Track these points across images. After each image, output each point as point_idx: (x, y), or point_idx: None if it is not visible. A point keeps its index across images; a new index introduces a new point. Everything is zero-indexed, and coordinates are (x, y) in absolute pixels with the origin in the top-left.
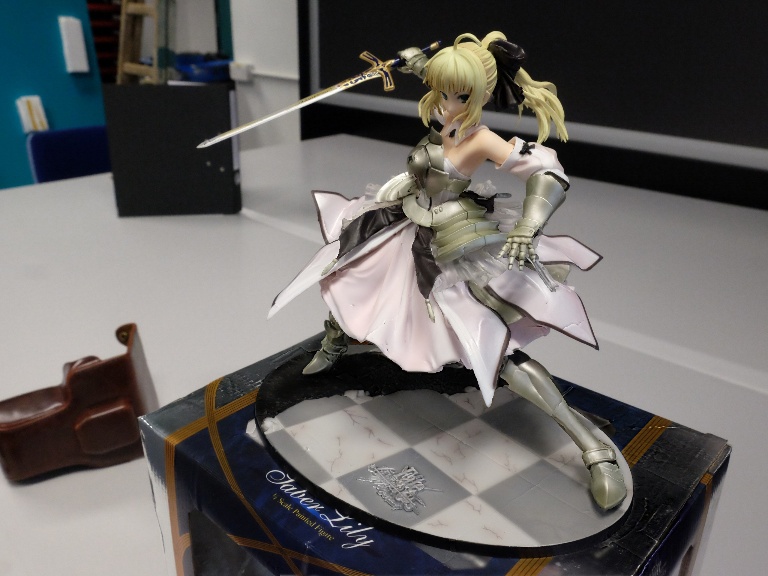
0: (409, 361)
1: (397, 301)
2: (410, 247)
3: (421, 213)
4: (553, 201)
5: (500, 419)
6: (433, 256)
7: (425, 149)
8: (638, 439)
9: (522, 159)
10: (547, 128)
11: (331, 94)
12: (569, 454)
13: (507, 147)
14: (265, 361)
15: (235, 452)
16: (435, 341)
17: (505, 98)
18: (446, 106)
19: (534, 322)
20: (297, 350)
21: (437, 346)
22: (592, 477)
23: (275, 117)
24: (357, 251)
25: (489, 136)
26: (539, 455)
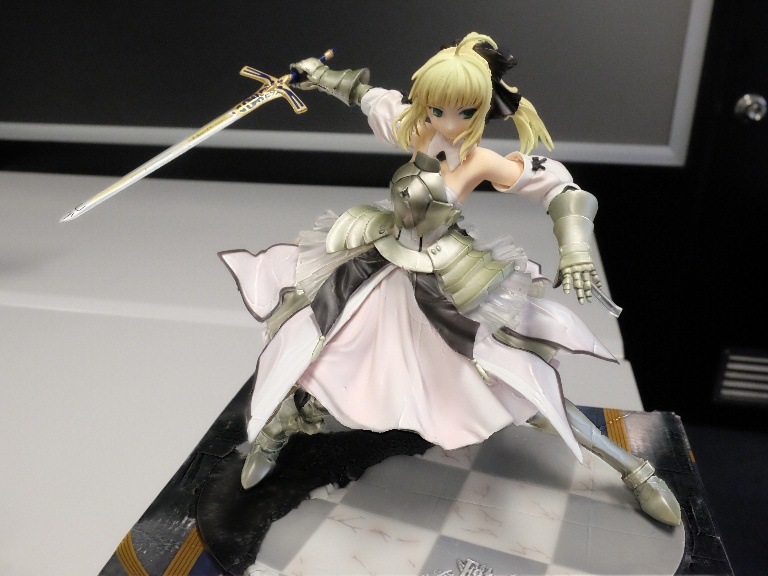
0: (445, 437)
1: (402, 369)
2: (398, 300)
3: (413, 257)
4: (590, 218)
5: (493, 464)
6: (454, 306)
7: (420, 179)
8: (613, 438)
9: (536, 176)
10: (533, 138)
11: (228, 124)
12: (586, 478)
13: (510, 165)
14: (171, 488)
15: None
16: (478, 405)
17: (495, 109)
18: (440, 125)
19: (573, 353)
20: (201, 458)
21: (483, 410)
22: (640, 496)
23: (163, 163)
24: (337, 319)
25: (490, 154)
26: (562, 490)
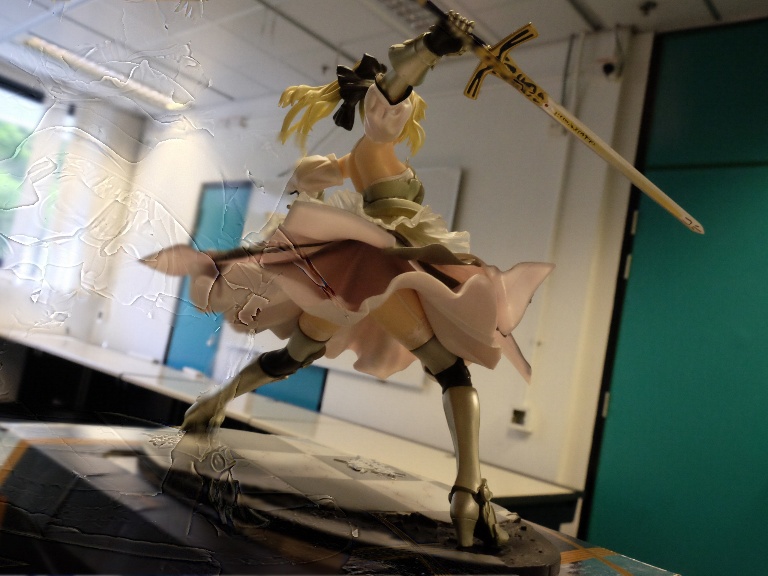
0: None
1: (190, 267)
2: None
3: None
4: None
5: None
6: None
7: None
8: None
9: None
10: None
11: None
12: None
13: None
14: None
15: (365, 517)
16: None
17: None
18: None
19: None
20: None
21: None
22: None
23: (414, 8)
24: None
25: None
26: None
